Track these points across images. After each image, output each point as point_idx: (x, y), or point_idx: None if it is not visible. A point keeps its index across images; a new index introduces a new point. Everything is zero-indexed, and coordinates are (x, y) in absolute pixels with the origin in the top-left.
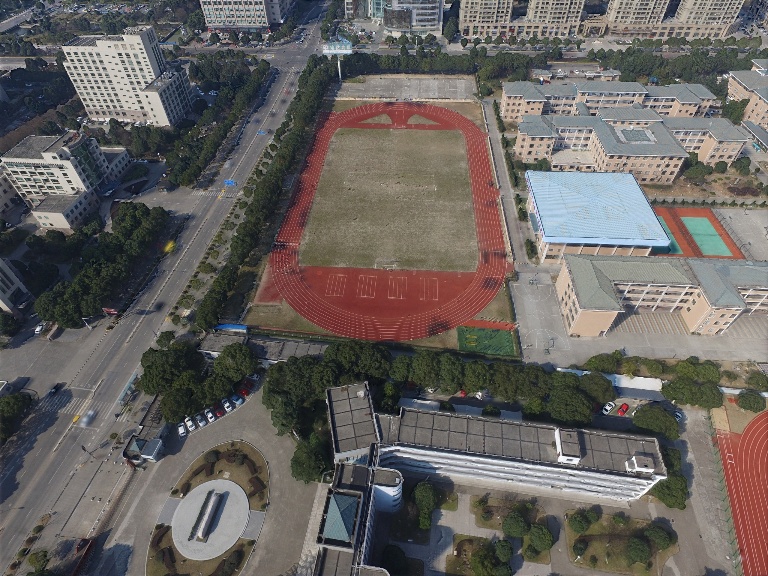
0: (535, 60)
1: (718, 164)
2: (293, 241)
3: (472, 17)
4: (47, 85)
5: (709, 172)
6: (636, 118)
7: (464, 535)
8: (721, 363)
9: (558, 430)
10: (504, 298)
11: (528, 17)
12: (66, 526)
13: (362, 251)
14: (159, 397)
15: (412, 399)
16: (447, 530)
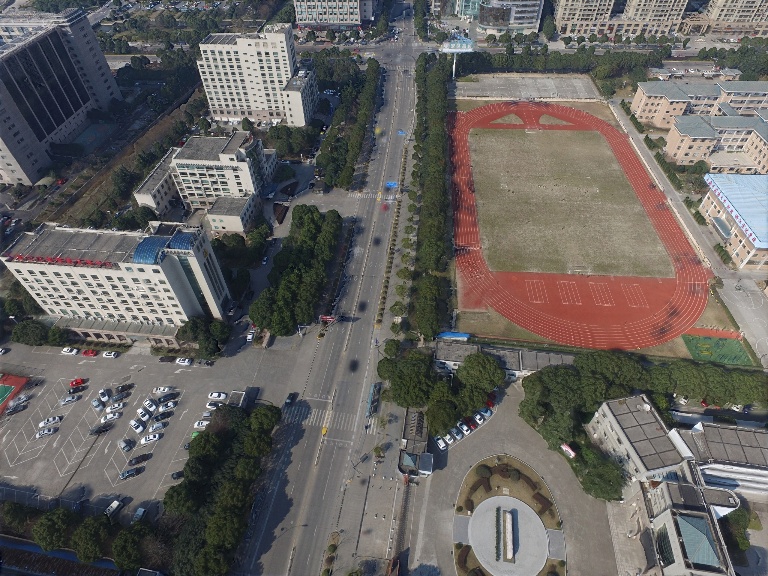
0: (650, 59)
1: None
2: (473, 245)
3: (571, 15)
4: (154, 84)
5: None
6: None
7: None
8: None
9: None
10: (717, 305)
11: (627, 15)
12: (359, 545)
13: (549, 256)
14: (410, 409)
15: (672, 411)
16: (762, 550)
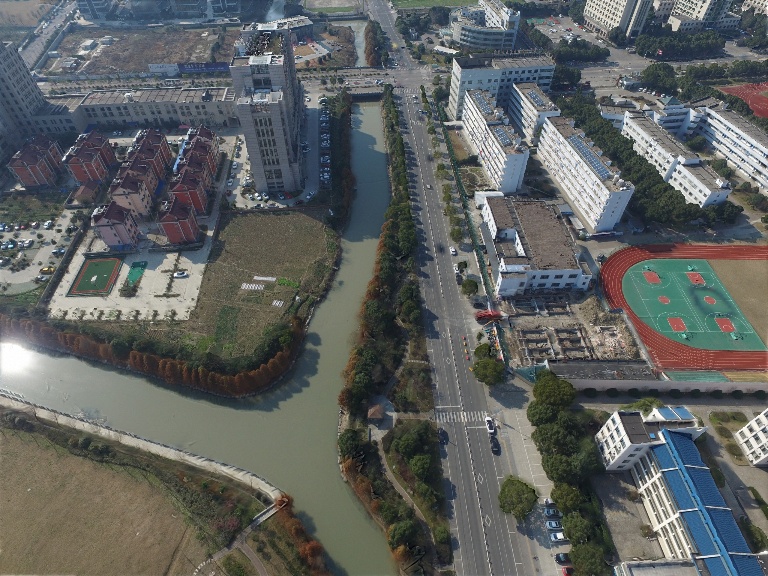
0: None
1: None
2: None
3: None
4: None
5: None
6: None
7: None
8: None
9: None
10: None
11: None
12: None
13: None
14: None
15: None
16: None
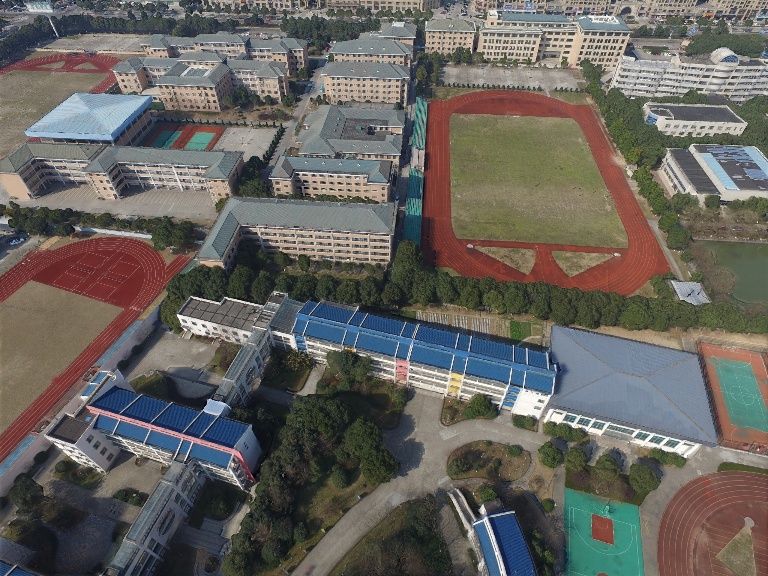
0: (225, 24)
1: (264, 97)
2: None
3: None
4: None
5: (256, 103)
6: (201, 59)
7: None
8: (95, 215)
9: None
10: None
11: None
12: None
13: None
14: None
15: None
16: None
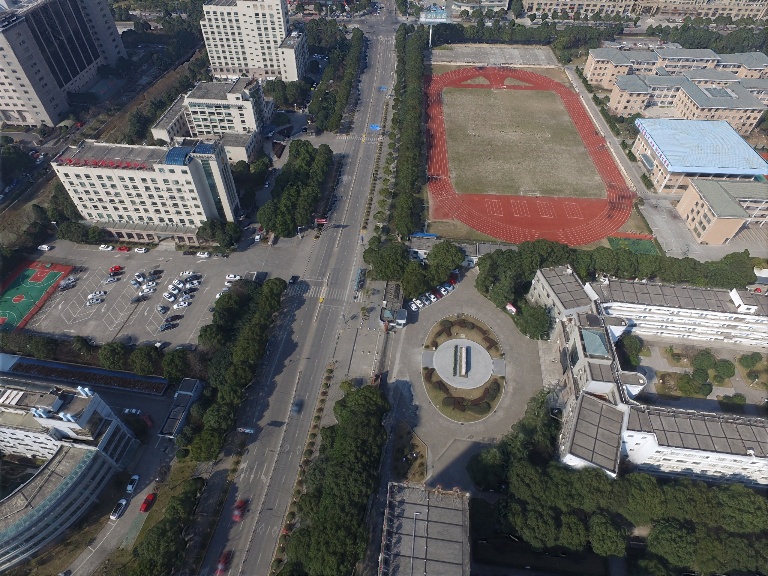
0: (603, 33)
1: None
2: (443, 175)
3: None
4: (155, 47)
5: None
6: (718, 78)
7: (663, 371)
8: None
9: (735, 290)
10: (637, 217)
11: None
12: (350, 369)
13: (506, 183)
14: (390, 282)
15: None
16: (649, 368)
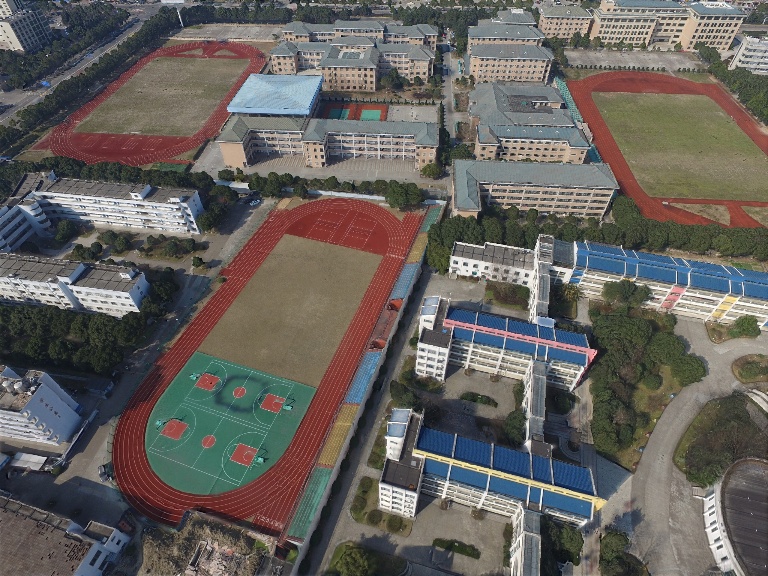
0: (340, 13)
1: (414, 78)
2: (77, 120)
3: None
4: None
5: (406, 84)
6: (354, 43)
7: (84, 246)
8: None
9: None
10: None
11: None
12: None
13: (121, 125)
14: None
15: None
16: (75, 244)
